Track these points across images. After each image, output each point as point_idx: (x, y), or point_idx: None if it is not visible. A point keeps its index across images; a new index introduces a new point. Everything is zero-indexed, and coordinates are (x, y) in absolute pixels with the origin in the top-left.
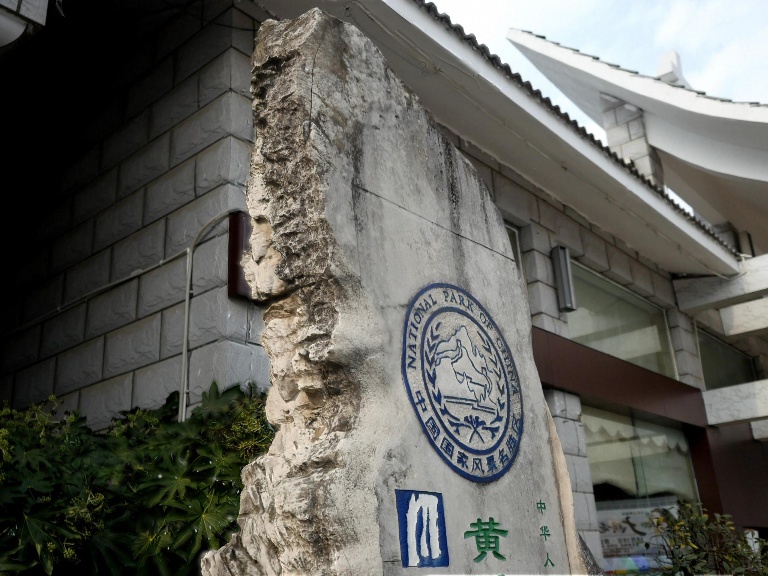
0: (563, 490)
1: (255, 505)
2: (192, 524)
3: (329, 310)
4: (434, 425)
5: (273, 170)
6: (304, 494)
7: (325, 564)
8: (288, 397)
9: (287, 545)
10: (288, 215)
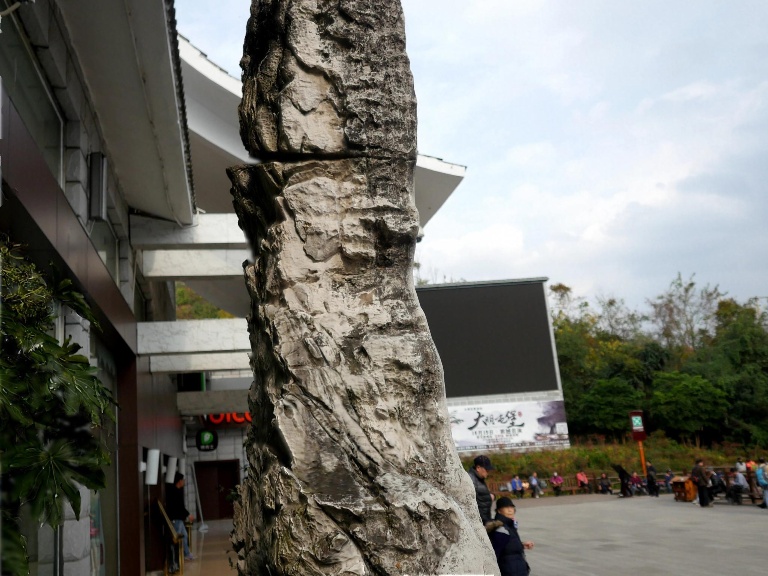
0: None
1: (318, 357)
2: None
3: (395, 187)
4: None
5: (350, 29)
6: (416, 350)
7: (421, 413)
8: (322, 257)
9: (381, 396)
10: (370, 83)
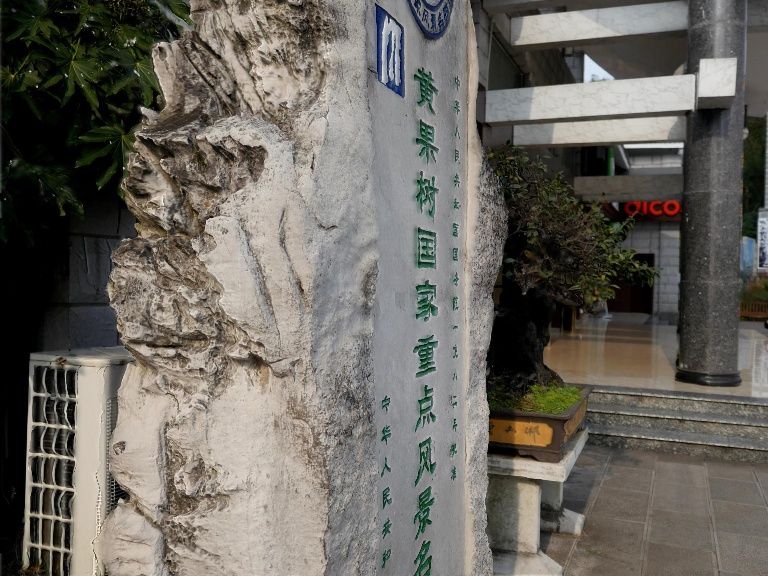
0: (472, 75)
1: None
2: (61, 67)
3: None
4: None
5: None
6: None
7: (312, 57)
8: None
9: (265, 37)
10: None
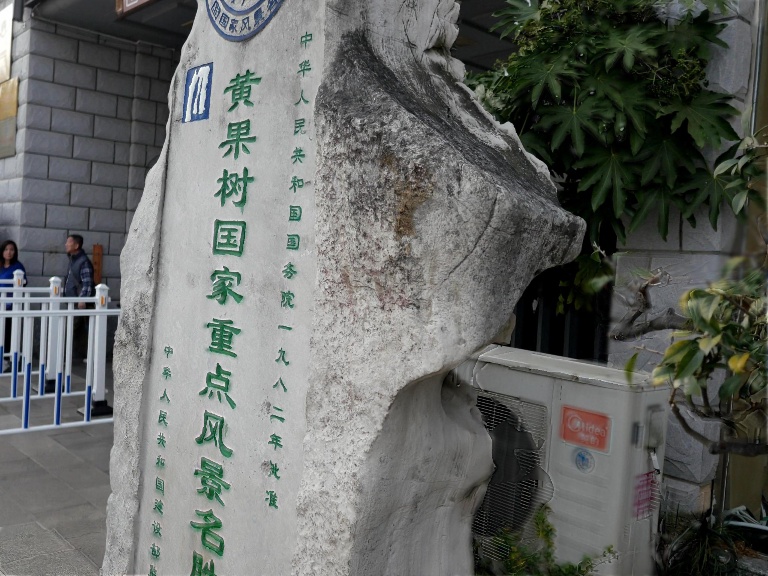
0: None
1: None
2: None
3: None
4: (217, 6)
5: None
6: None
7: None
8: None
9: None
10: None
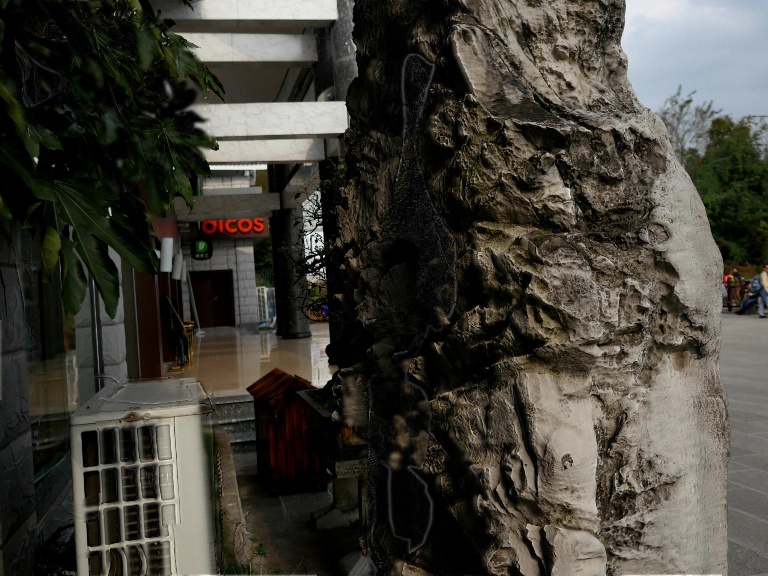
0: None
1: None
2: None
3: None
4: None
5: None
6: None
7: (601, 57)
8: None
9: (561, 32)
10: None
